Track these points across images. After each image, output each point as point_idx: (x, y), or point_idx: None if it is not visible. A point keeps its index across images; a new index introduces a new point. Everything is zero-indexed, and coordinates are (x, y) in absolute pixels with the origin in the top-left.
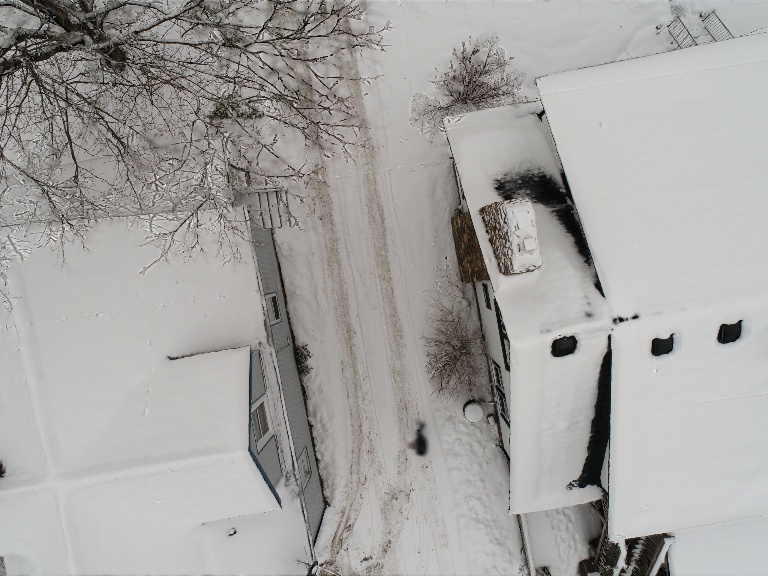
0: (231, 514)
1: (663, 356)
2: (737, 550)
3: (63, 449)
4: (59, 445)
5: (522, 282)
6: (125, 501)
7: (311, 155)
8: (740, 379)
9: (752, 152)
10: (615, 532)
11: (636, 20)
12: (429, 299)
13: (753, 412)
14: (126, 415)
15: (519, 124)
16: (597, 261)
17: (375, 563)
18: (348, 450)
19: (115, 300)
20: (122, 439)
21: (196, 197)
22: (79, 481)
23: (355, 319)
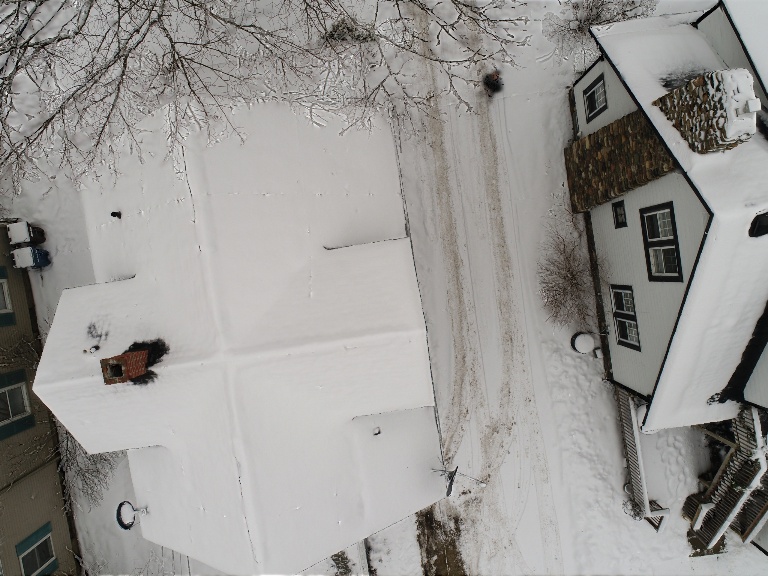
0: (387, 406)
1: None
2: None
3: (233, 325)
4: (230, 321)
5: (716, 162)
6: (288, 384)
7: (424, 81)
8: None
9: None
10: None
11: None
12: (540, 229)
13: None
14: (291, 297)
15: (674, 31)
16: None
17: (473, 497)
18: (451, 381)
19: (280, 182)
20: (290, 319)
21: None
22: (251, 356)
23: (463, 248)
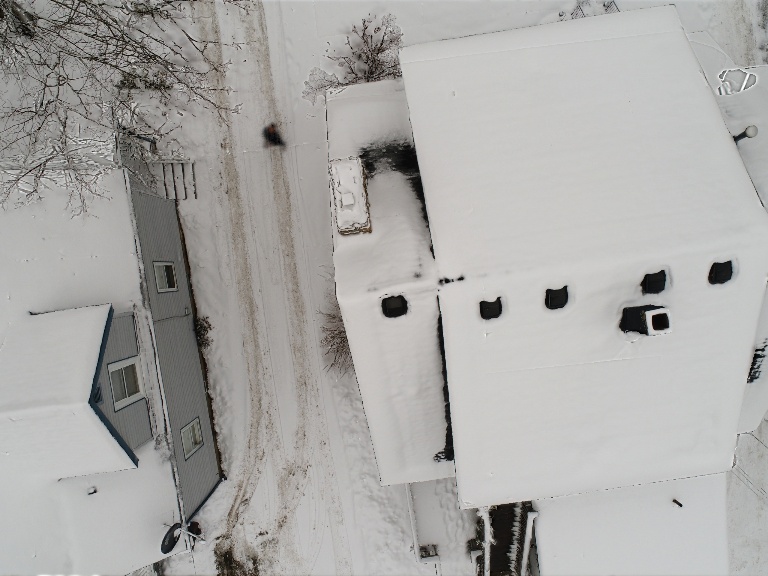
0: (84, 470)
1: (493, 320)
2: (602, 527)
3: None
4: None
5: (360, 243)
6: None
7: (219, 129)
8: (571, 346)
9: (594, 124)
10: (463, 499)
11: (541, 7)
12: None
13: (588, 381)
14: None
15: (396, 97)
16: (431, 224)
17: (270, 538)
18: (247, 424)
19: None
20: None
21: (88, 162)
22: None
23: (258, 293)
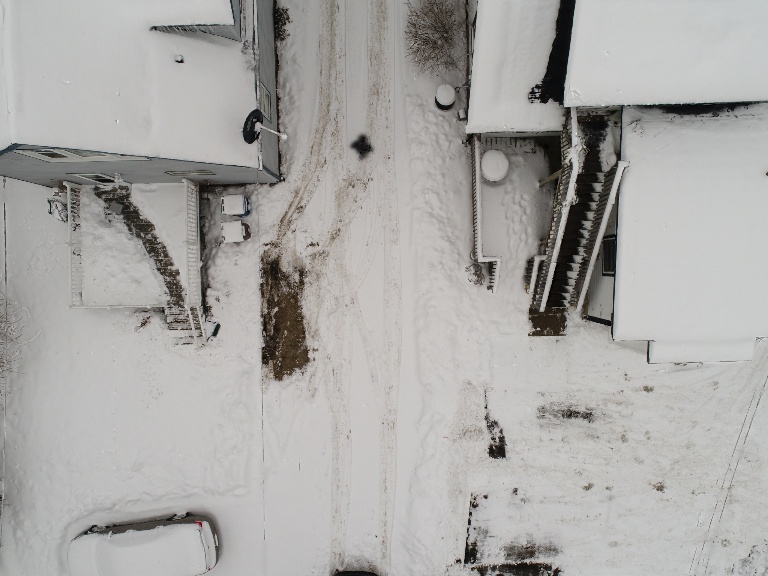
0: (181, 10)
1: None
2: (689, 195)
3: None
4: None
5: None
6: None
7: None
8: None
9: None
10: (571, 86)
11: None
12: None
13: None
14: None
15: None
16: None
17: (321, 250)
18: (312, 127)
19: None
20: None
21: None
22: None
23: None
